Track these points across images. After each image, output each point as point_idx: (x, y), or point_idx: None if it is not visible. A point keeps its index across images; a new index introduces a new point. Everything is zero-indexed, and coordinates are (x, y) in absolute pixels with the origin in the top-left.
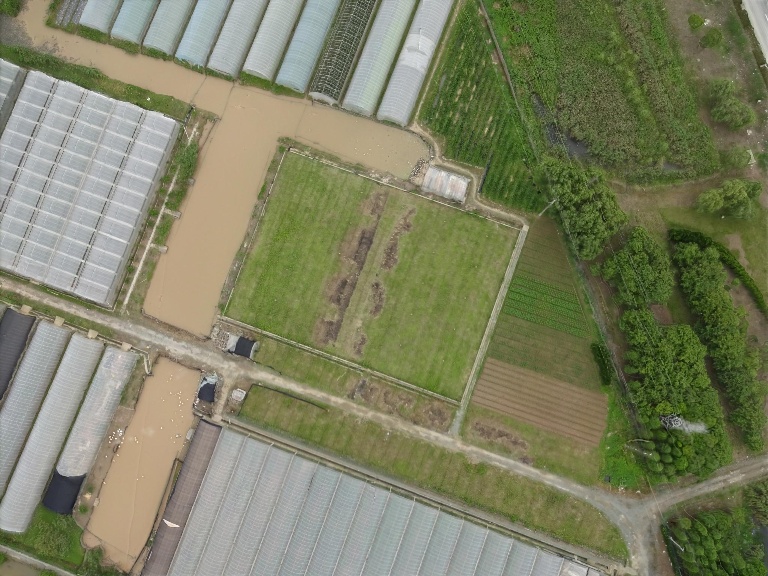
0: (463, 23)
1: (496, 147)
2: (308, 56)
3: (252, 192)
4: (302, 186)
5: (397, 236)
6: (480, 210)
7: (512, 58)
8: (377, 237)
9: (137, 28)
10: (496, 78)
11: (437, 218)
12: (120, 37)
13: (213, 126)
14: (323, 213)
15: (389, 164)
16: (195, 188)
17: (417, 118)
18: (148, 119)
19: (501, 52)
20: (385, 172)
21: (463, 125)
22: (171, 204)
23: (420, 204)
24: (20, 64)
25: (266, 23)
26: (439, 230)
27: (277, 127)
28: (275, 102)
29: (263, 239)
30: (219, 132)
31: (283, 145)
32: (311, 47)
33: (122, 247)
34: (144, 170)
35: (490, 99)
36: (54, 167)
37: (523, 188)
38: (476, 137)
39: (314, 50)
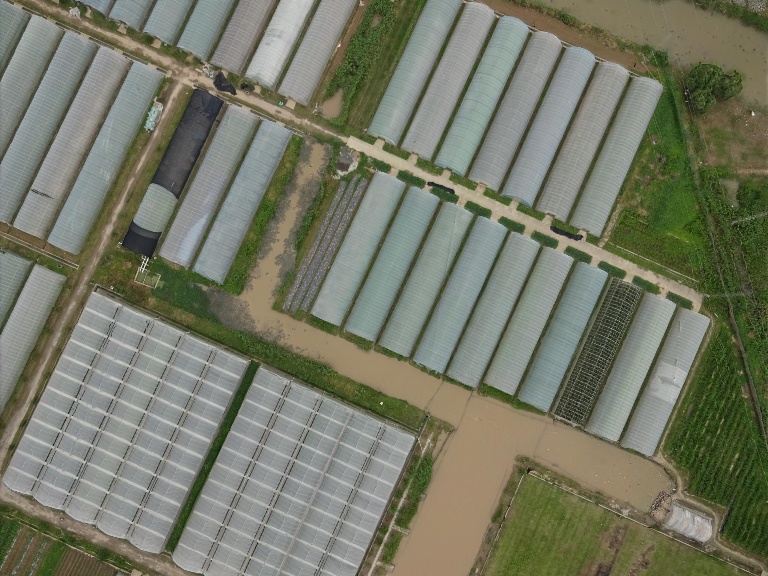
0: (716, 352)
1: (741, 487)
2: (558, 378)
3: (486, 513)
4: (539, 512)
5: (634, 573)
6: (720, 551)
7: (764, 394)
8: (614, 572)
9: (376, 328)
10: (746, 414)
11: (676, 557)
12: (355, 334)
13: (448, 437)
14: (560, 543)
15: (630, 494)
16: (426, 503)
17: (662, 448)
18: (389, 438)
19: (755, 390)
20: (625, 503)
21: (710, 462)
22: (403, 523)
23: (660, 541)
24: (243, 351)
25: (516, 338)
26: (677, 570)
27: (515, 444)
28: (514, 416)
29: (496, 566)
30: (454, 444)
31: (521, 465)
32: (561, 368)
33: (353, 573)
34: (382, 493)
35: (738, 435)
36: (283, 479)
37: (767, 535)
38: (721, 474)
39: (563, 370)
